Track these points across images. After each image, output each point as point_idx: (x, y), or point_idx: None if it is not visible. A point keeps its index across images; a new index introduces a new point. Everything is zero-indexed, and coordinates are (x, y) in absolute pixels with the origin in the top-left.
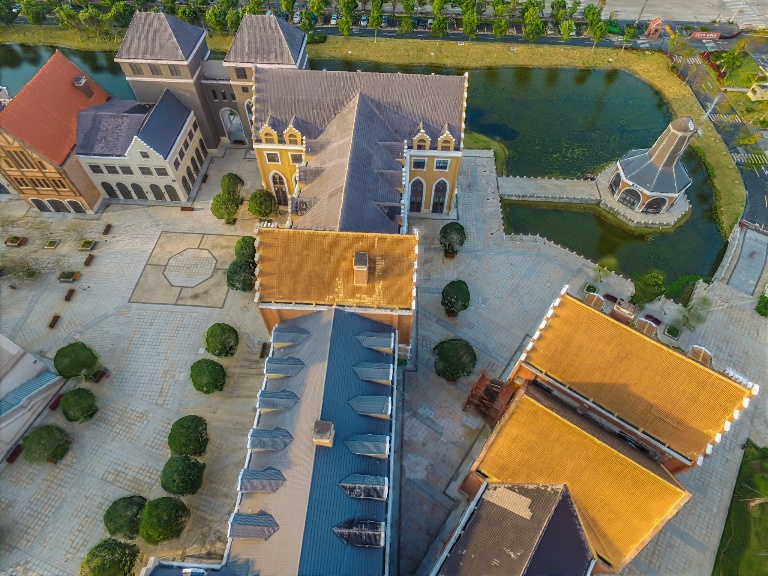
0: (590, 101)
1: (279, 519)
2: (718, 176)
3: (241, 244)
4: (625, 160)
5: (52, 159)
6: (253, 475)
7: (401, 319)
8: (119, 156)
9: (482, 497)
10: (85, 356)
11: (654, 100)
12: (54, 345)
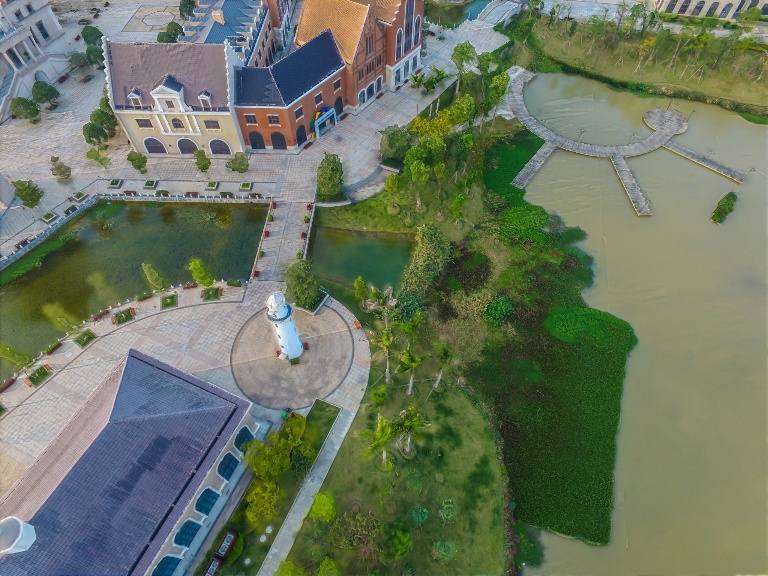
0: None
1: None
2: None
3: None
4: None
5: None
6: None
7: None
8: None
9: None
10: (99, 31)
11: None
12: (79, 47)
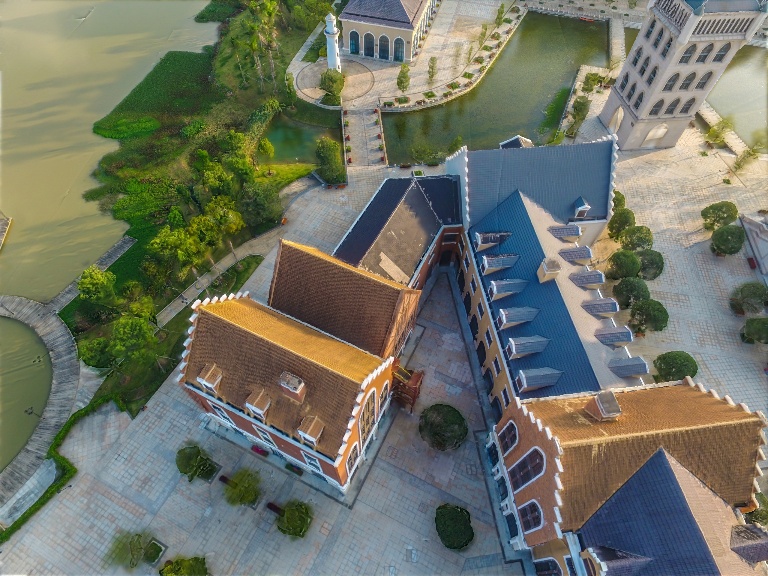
0: None
1: None
2: None
3: None
4: None
5: None
6: (583, 253)
7: None
8: None
9: None
10: None
11: None
12: None
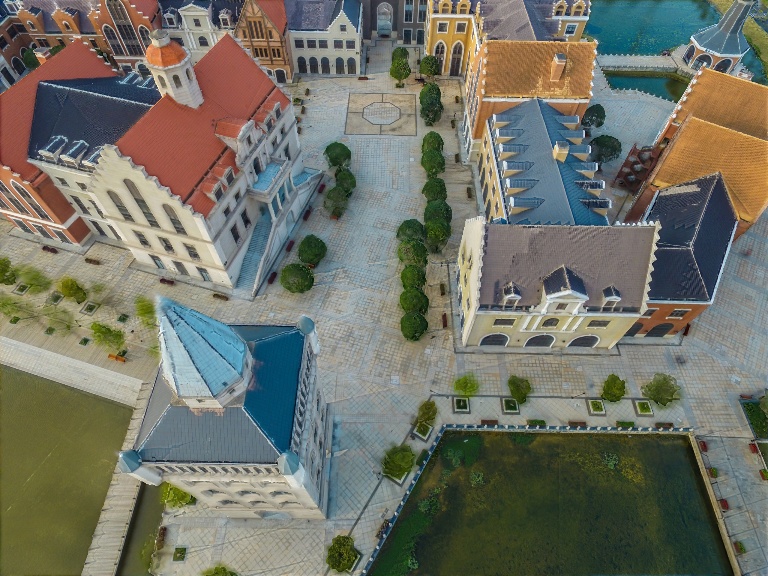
0: (652, 7)
1: (543, 197)
2: (763, 53)
3: (430, 87)
4: (698, 34)
5: (279, 29)
6: (516, 179)
7: (578, 109)
8: (322, 31)
9: (659, 195)
10: (348, 149)
11: (703, 6)
12: None
